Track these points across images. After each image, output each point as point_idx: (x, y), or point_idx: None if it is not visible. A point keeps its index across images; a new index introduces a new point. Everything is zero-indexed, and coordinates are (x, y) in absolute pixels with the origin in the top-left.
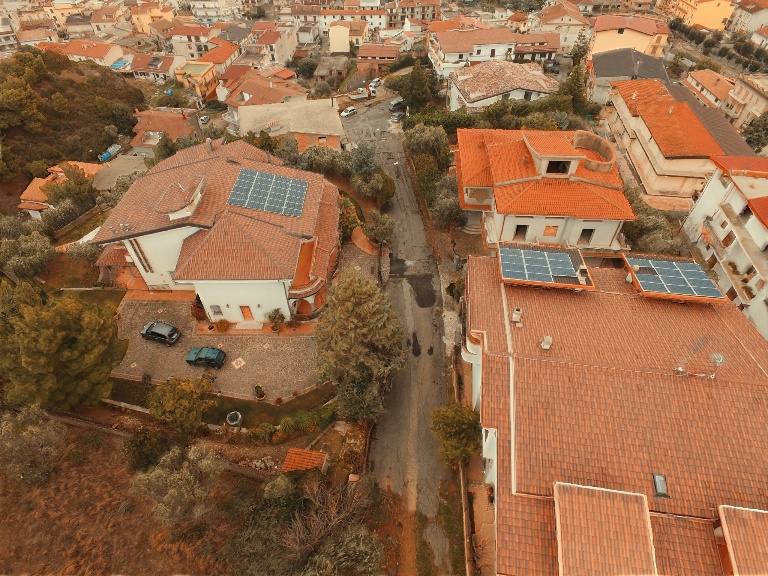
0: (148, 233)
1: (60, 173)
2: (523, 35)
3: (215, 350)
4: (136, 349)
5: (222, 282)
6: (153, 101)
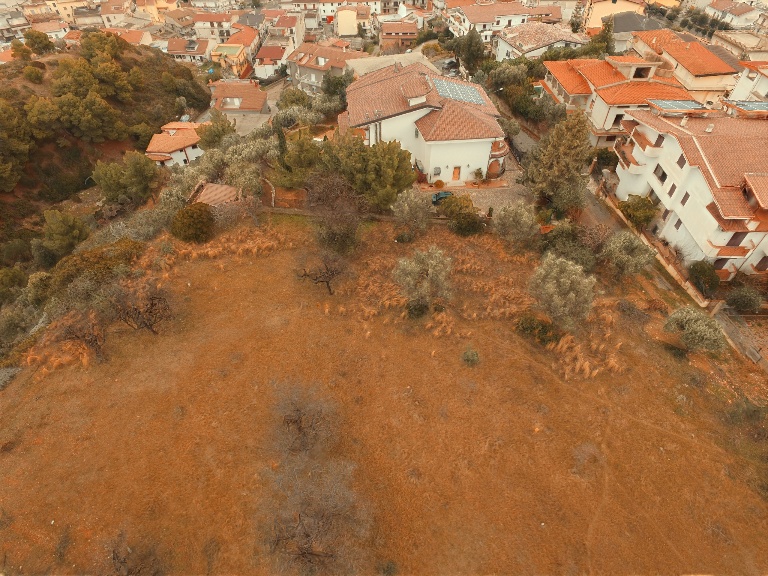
0: (397, 115)
1: (172, 130)
2: (530, 8)
3: (449, 193)
4: None
5: (458, 142)
6: (200, 79)
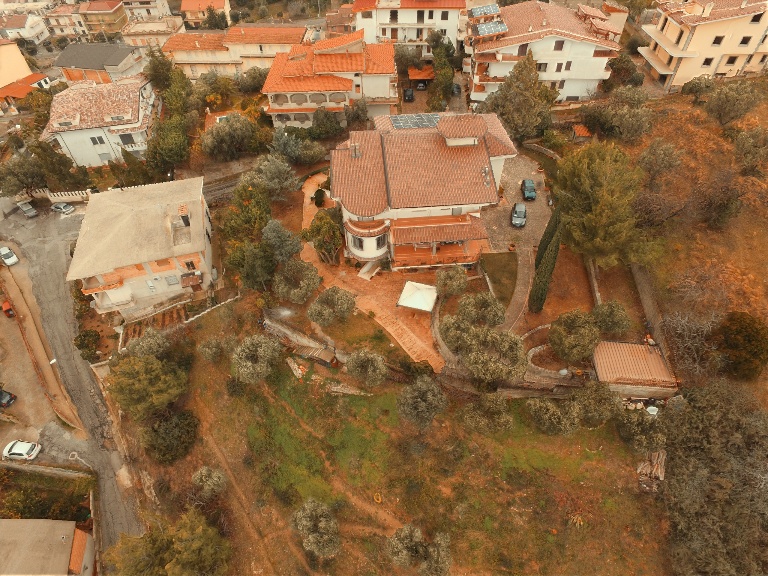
0: None
1: None
2: None
3: (526, 180)
4: (534, 228)
5: None
6: None
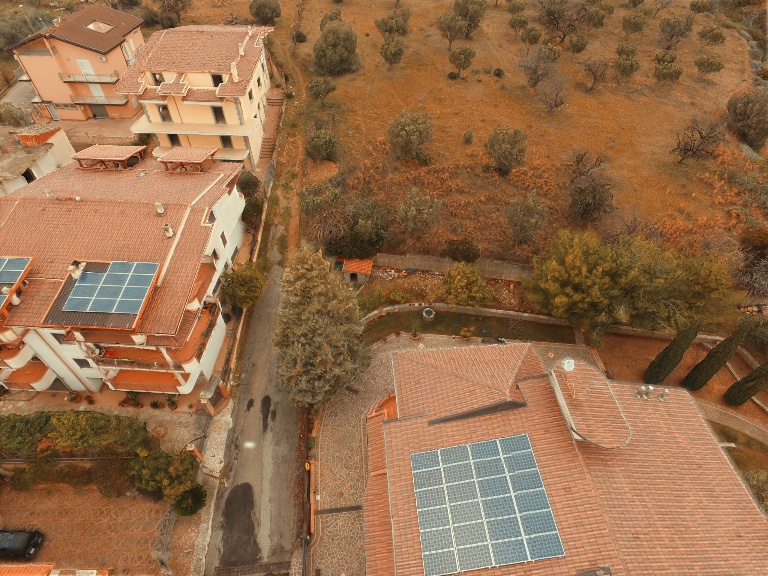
0: None
1: None
2: None
3: None
4: None
5: None
6: None
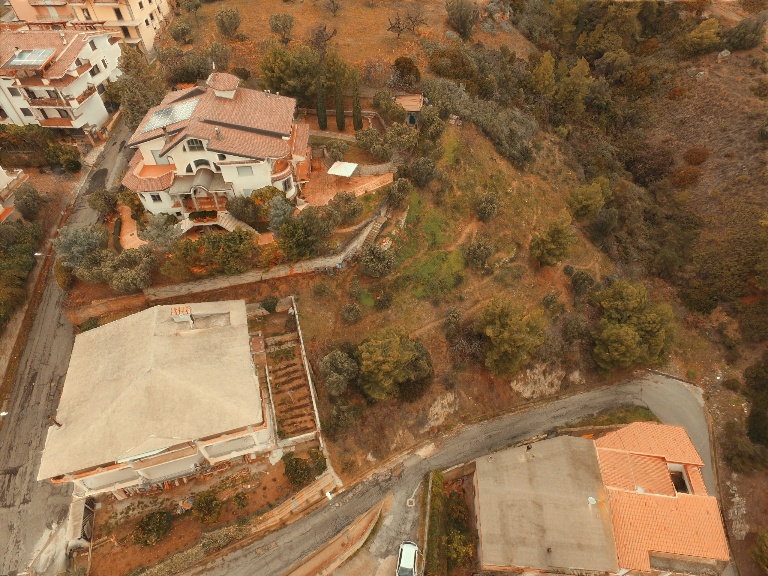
0: None
1: None
2: None
3: None
4: None
5: None
6: None
